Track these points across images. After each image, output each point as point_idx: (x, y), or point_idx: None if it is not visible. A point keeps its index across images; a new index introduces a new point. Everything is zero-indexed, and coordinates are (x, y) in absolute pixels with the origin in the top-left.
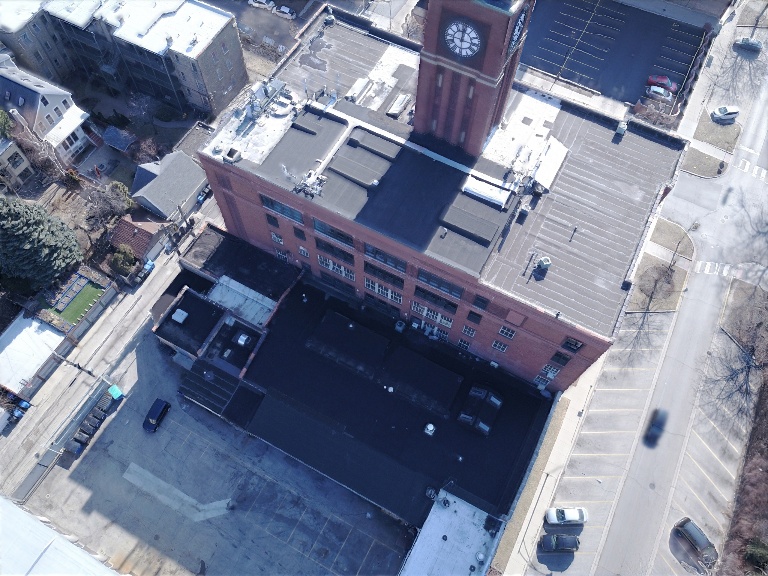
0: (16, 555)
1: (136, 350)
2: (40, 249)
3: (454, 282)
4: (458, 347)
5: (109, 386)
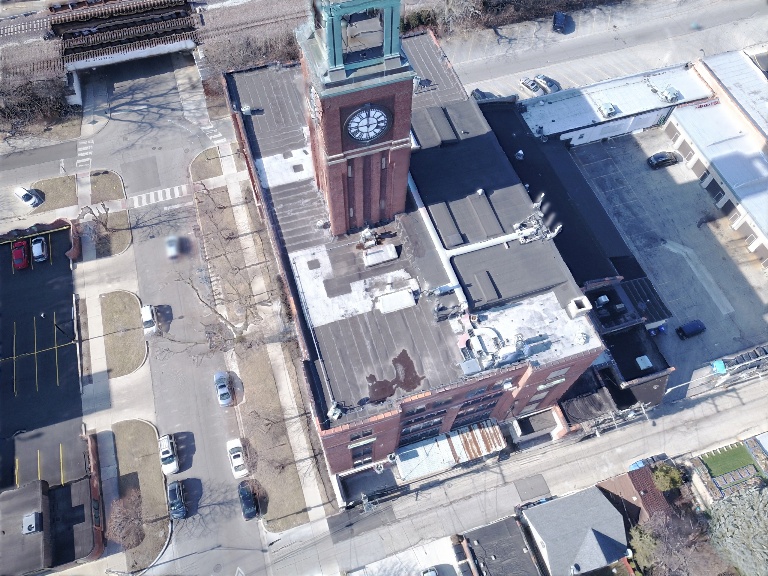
0: None
1: None
2: None
3: None
4: None
5: None
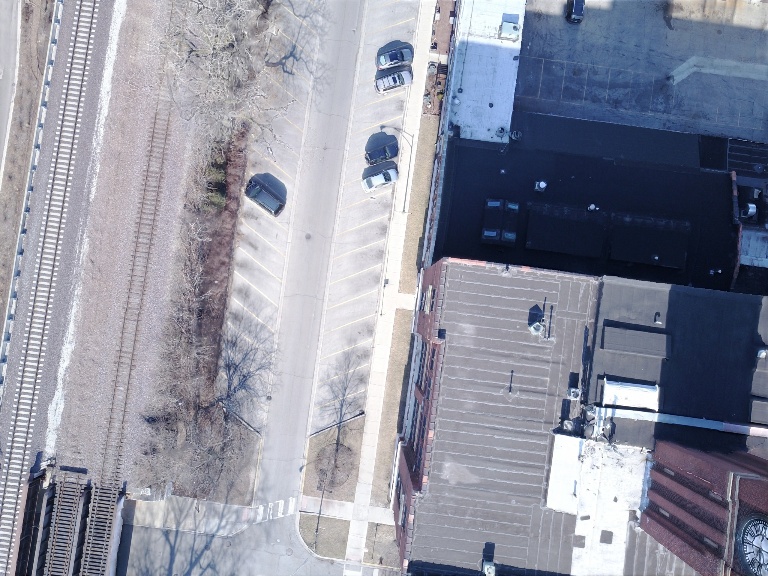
0: None
1: None
2: None
3: None
4: None
5: None
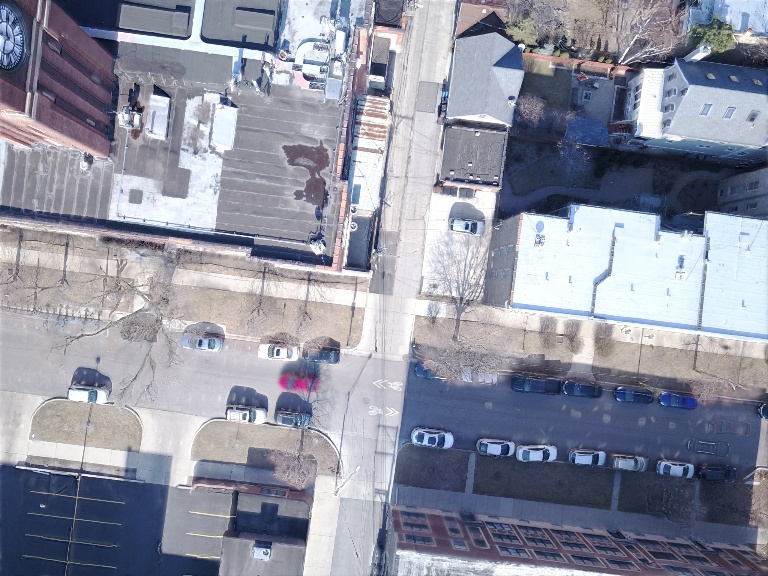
0: None
1: None
2: None
3: None
4: None
5: None
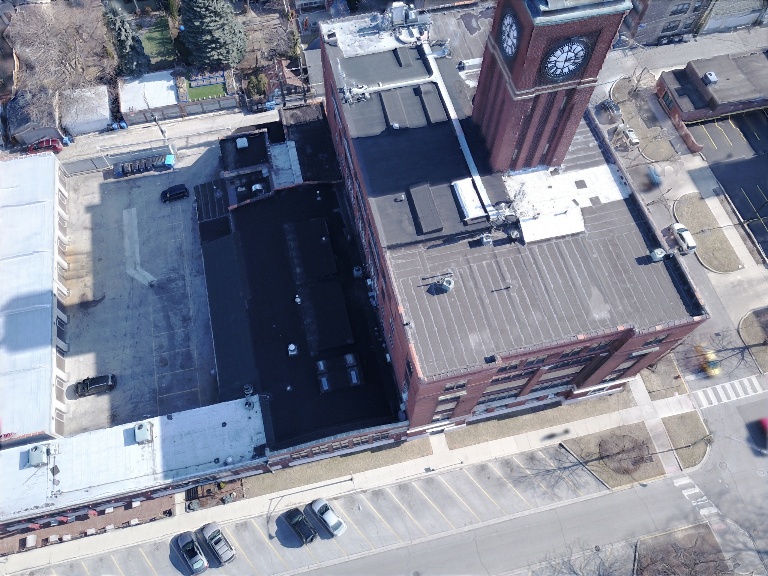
0: (27, 192)
1: (209, 149)
2: (206, 33)
3: (377, 243)
4: (381, 324)
5: (170, 153)
